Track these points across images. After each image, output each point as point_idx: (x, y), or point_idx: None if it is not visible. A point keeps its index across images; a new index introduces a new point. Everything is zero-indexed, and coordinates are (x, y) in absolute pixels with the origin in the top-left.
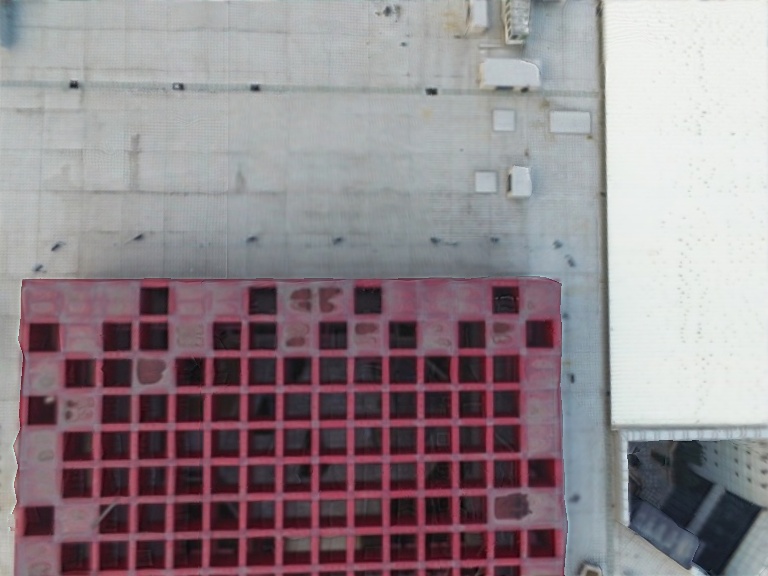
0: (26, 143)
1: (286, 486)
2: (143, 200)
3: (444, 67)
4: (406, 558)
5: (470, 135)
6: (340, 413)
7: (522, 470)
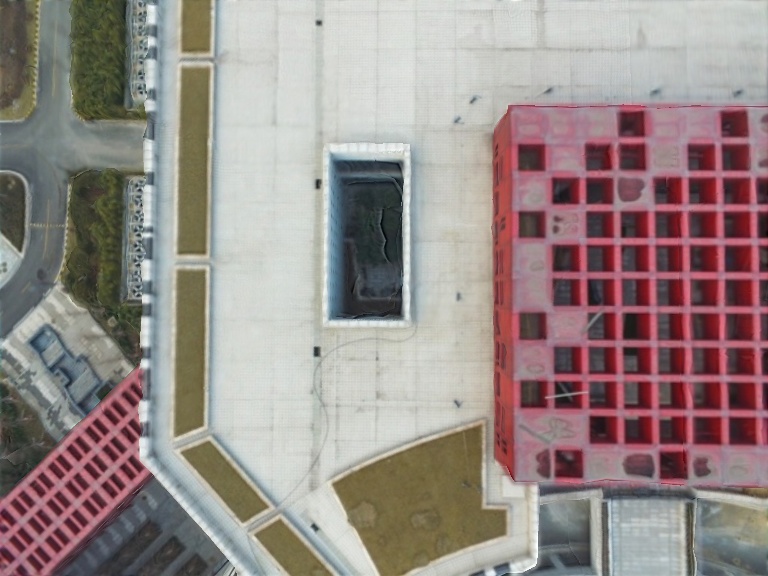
0: (441, 5)
1: (762, 300)
2: (550, 56)
3: None
4: None
5: None
6: None
7: None
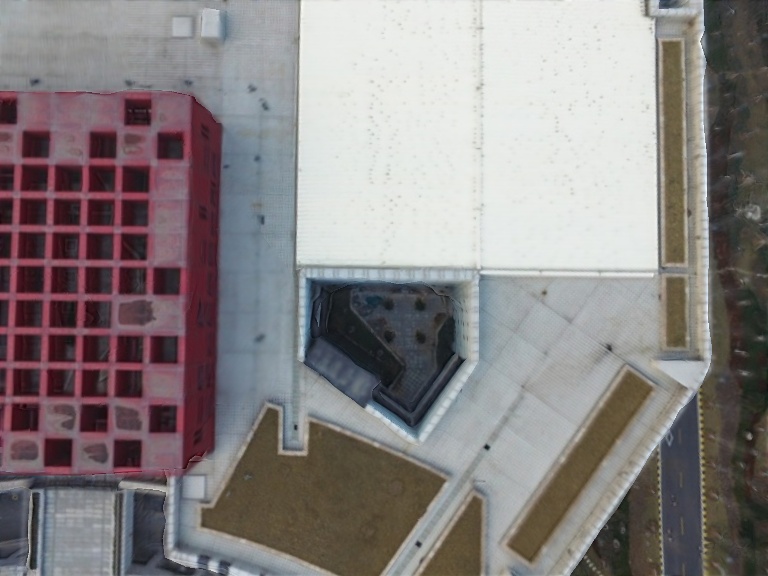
0: None
1: None
2: None
3: None
4: (30, 359)
5: None
6: None
7: (148, 278)
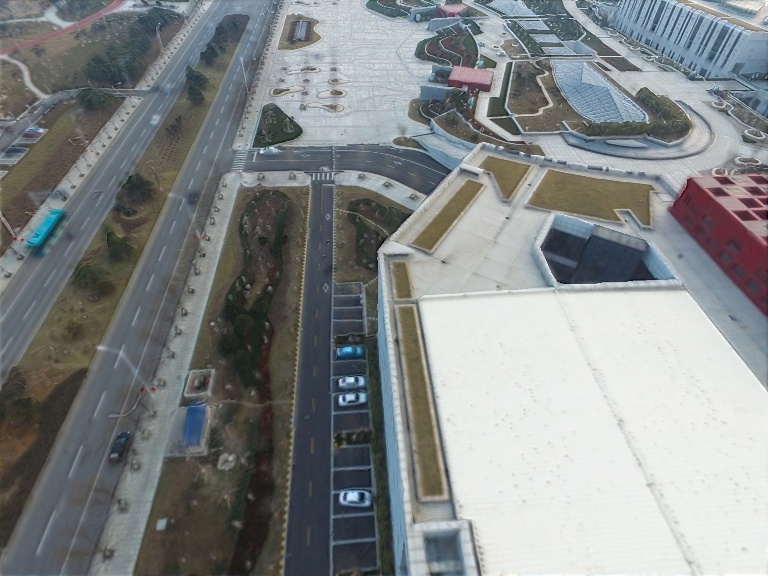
0: None
1: None
2: None
3: None
4: None
5: None
6: None
7: None
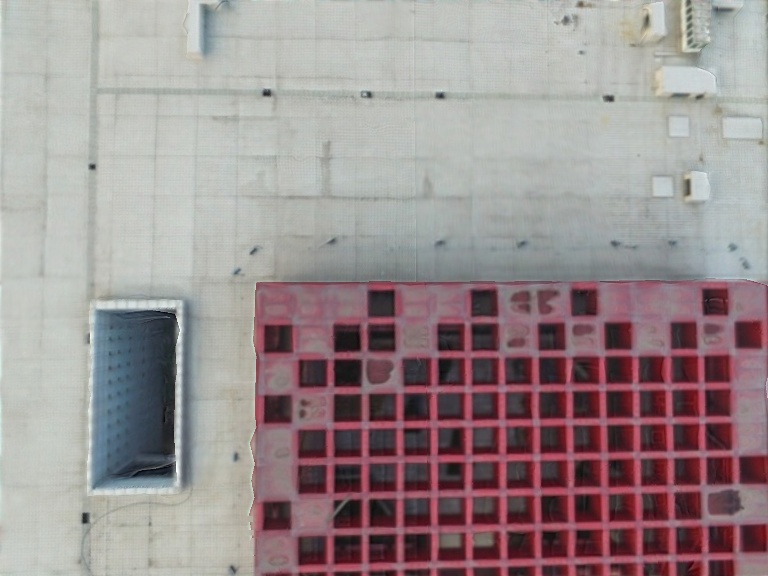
0: (223, 150)
1: (509, 482)
2: (335, 205)
3: (620, 75)
4: (624, 552)
5: (646, 141)
6: (559, 412)
7: (733, 467)
